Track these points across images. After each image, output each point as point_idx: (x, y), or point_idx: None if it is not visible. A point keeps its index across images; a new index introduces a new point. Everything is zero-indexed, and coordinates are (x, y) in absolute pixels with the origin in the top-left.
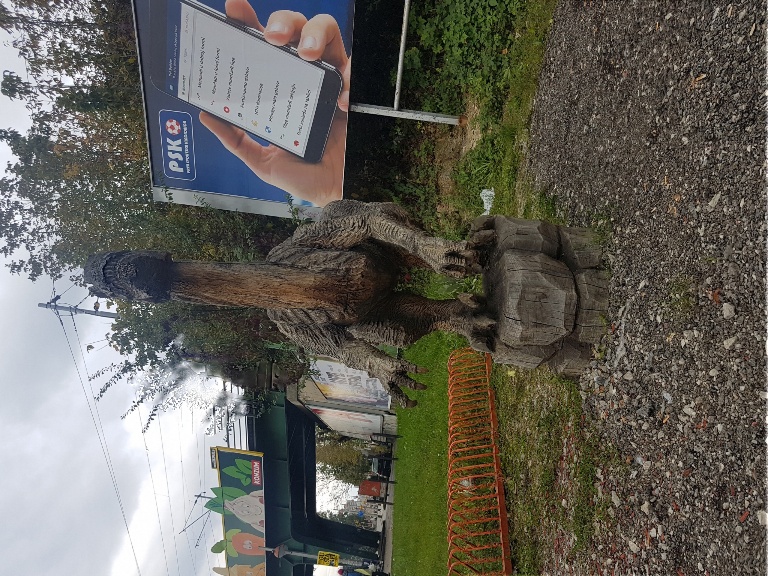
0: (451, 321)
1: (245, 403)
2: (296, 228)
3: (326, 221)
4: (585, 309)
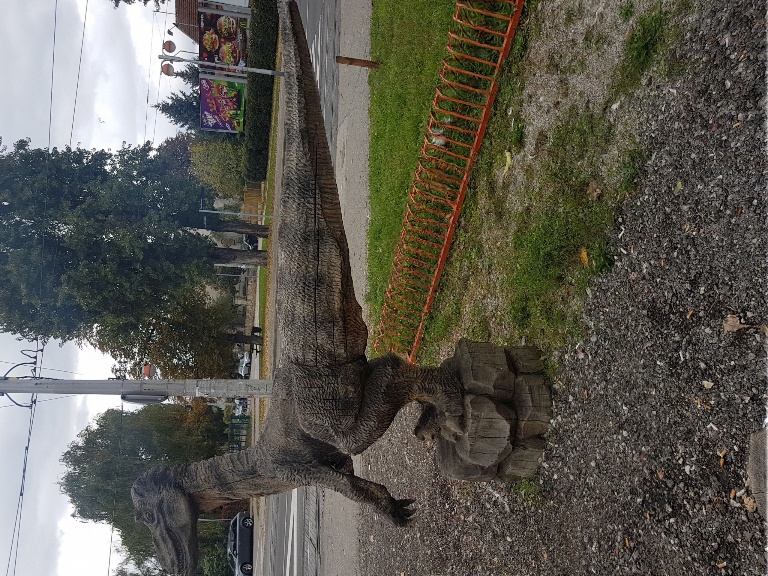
0: None
1: None
2: None
3: None
4: None
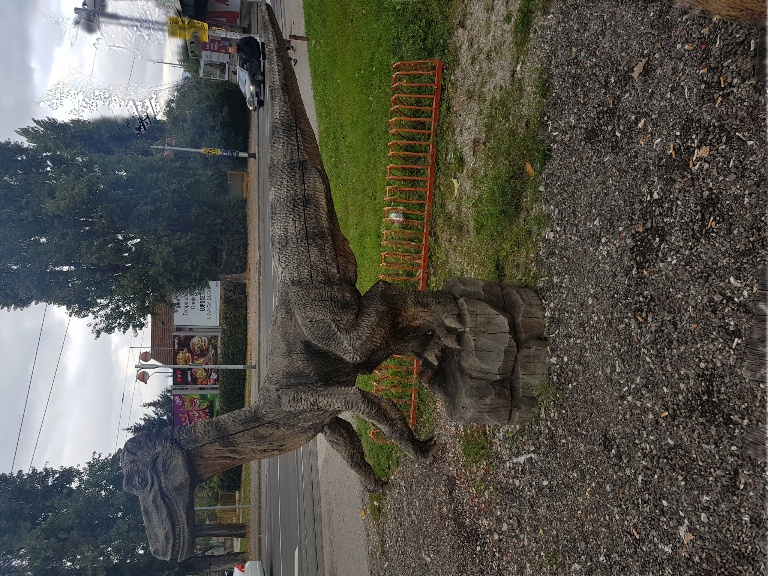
0: None
1: (166, 88)
2: (284, 402)
3: (312, 404)
4: None
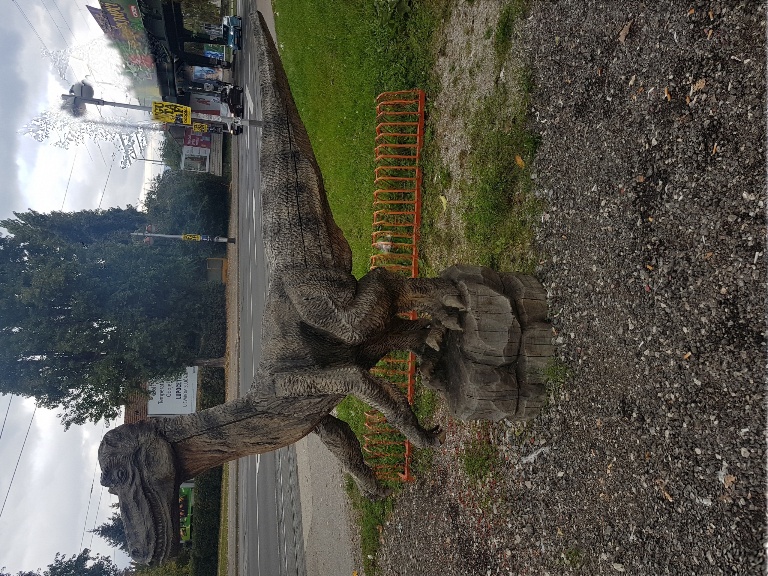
0: None
1: (153, 123)
2: (279, 386)
3: (310, 386)
4: None
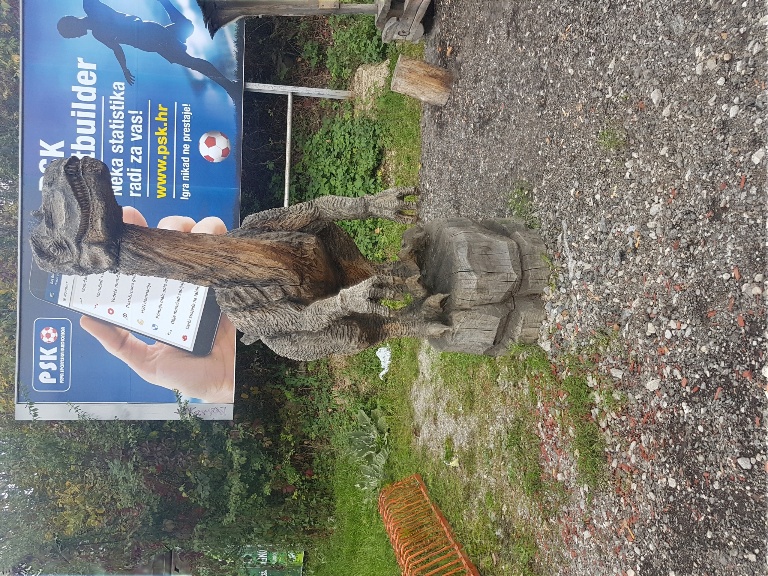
0: (401, 321)
1: None
2: None
3: None
4: (527, 254)
